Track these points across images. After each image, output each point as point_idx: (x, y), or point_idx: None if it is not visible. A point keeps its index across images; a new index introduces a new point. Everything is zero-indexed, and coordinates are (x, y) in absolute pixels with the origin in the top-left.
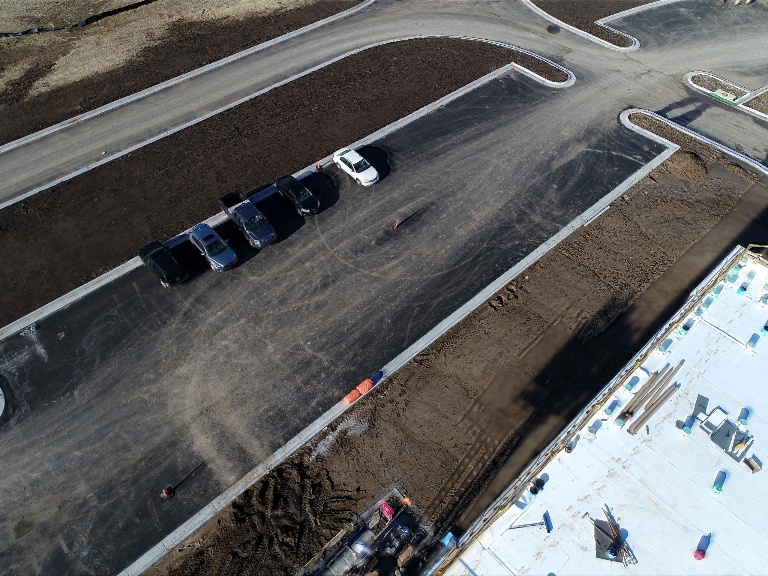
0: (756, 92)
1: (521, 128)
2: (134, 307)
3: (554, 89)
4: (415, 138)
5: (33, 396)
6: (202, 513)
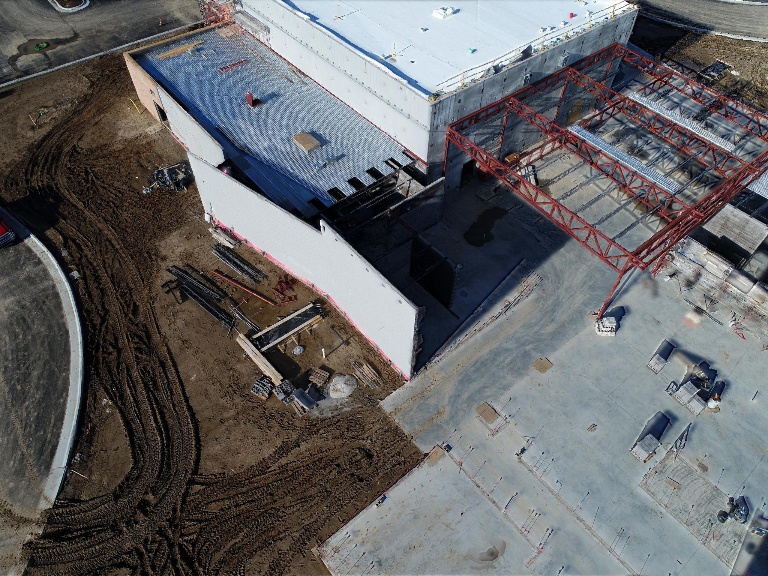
0: None
1: None
2: None
3: None
4: None
5: (102, 1)
6: None
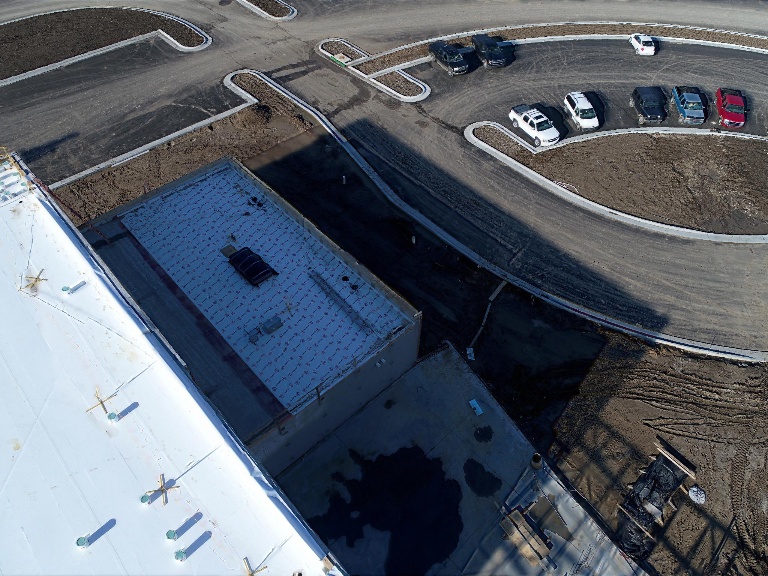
0: (374, 56)
1: (123, 86)
2: None
3: (182, 53)
4: (13, 94)
5: None
6: None
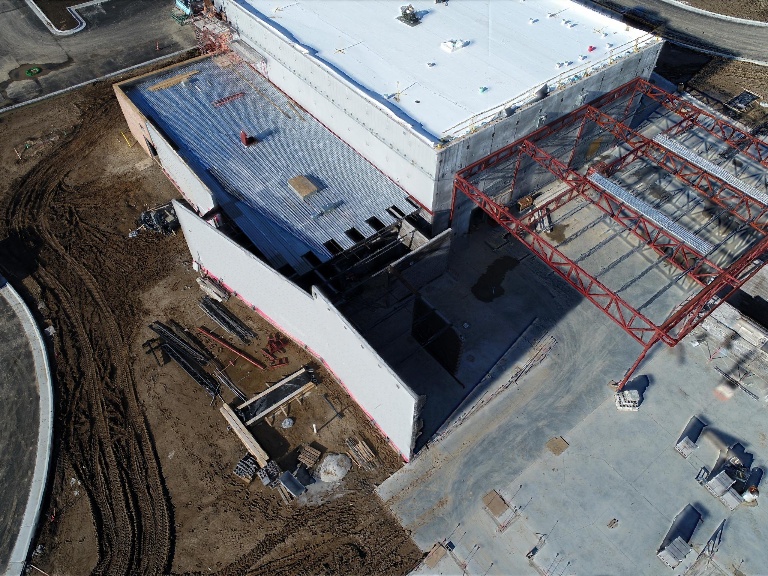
0: None
1: None
2: (150, 0)
3: None
4: None
5: (99, 23)
6: (173, 53)
